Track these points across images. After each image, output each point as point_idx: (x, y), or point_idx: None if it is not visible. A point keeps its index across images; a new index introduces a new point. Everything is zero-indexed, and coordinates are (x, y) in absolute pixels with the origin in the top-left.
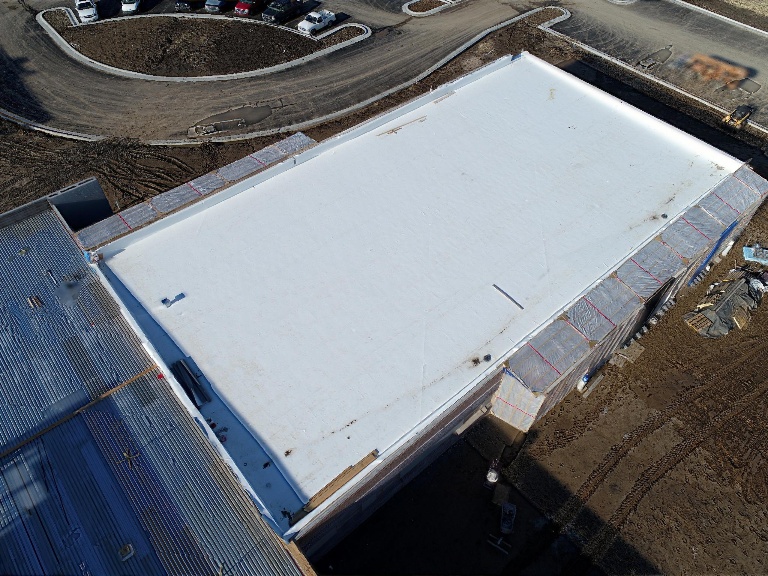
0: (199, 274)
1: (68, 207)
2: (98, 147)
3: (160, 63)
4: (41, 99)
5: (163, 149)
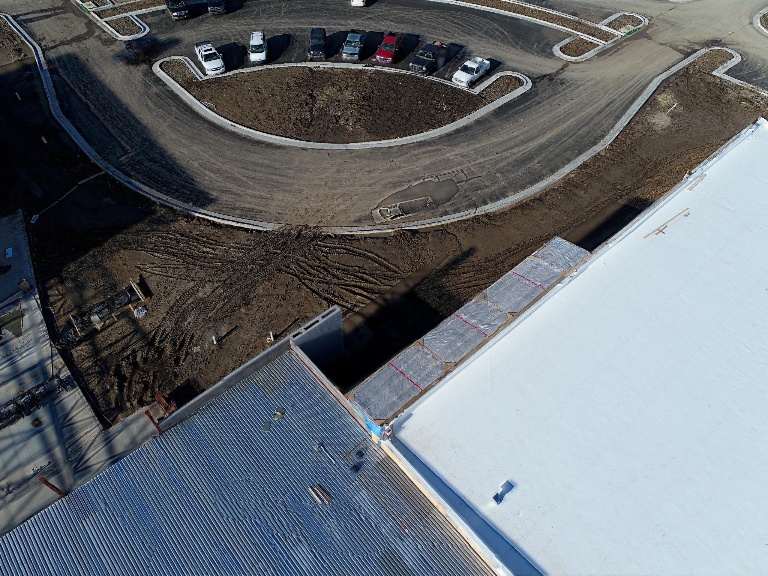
0: (517, 450)
1: (308, 345)
2: (277, 239)
3: (311, 125)
4: (190, 175)
5: (353, 240)
